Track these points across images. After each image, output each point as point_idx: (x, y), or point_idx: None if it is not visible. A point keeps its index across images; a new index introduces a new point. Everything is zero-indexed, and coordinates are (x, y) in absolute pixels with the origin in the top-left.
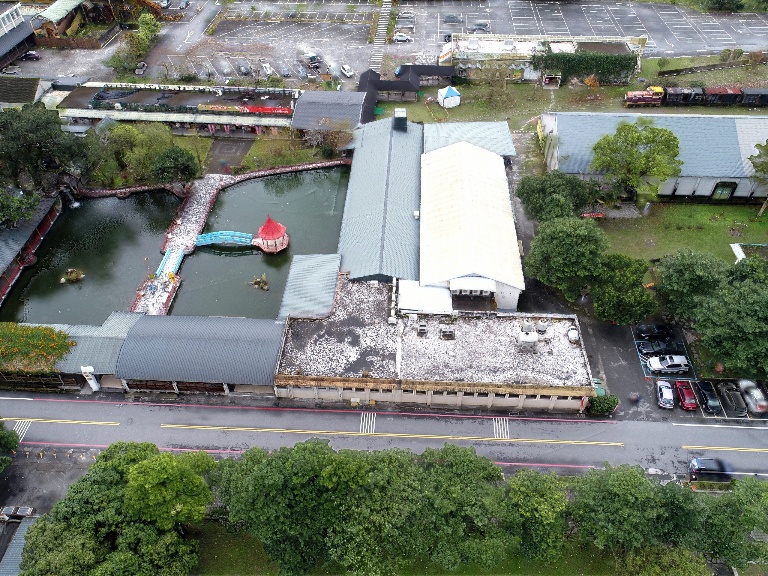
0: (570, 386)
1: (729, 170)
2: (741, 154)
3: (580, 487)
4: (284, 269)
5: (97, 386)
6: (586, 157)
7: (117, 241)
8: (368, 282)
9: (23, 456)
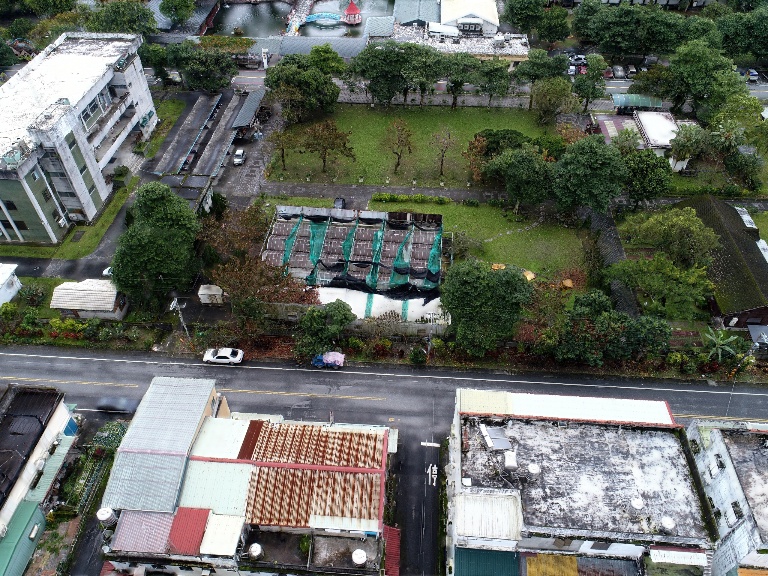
0: (519, 54)
1: None
2: None
3: None
4: (360, 32)
5: (267, 65)
6: None
7: (258, 20)
8: (411, 26)
9: (236, 87)
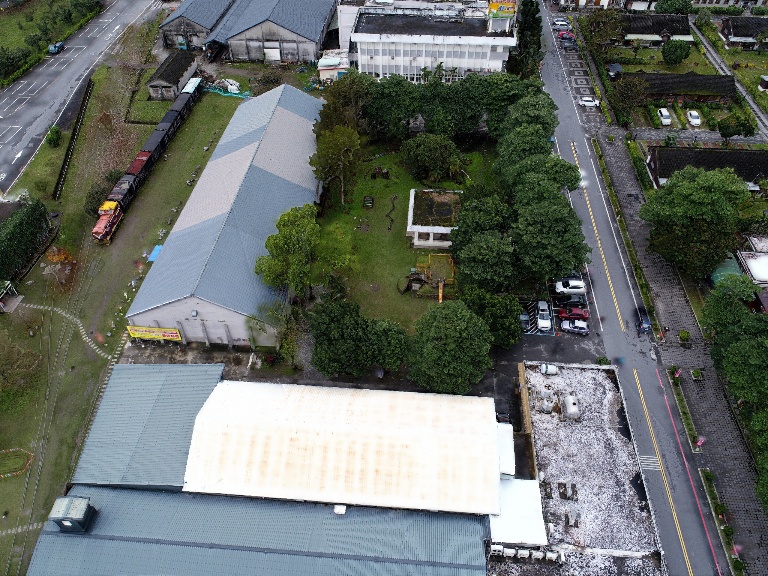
0: None
1: (306, 197)
2: (291, 181)
3: (766, 389)
4: None
5: None
6: (263, 293)
7: None
8: None
9: None
